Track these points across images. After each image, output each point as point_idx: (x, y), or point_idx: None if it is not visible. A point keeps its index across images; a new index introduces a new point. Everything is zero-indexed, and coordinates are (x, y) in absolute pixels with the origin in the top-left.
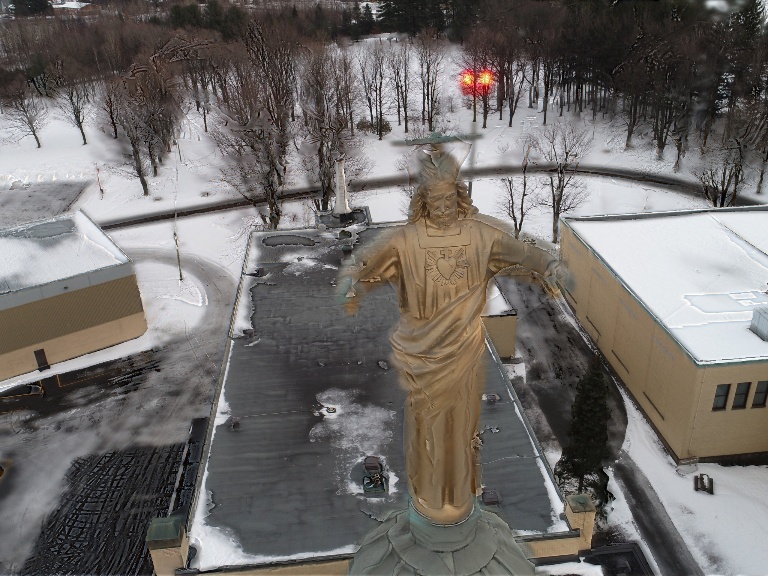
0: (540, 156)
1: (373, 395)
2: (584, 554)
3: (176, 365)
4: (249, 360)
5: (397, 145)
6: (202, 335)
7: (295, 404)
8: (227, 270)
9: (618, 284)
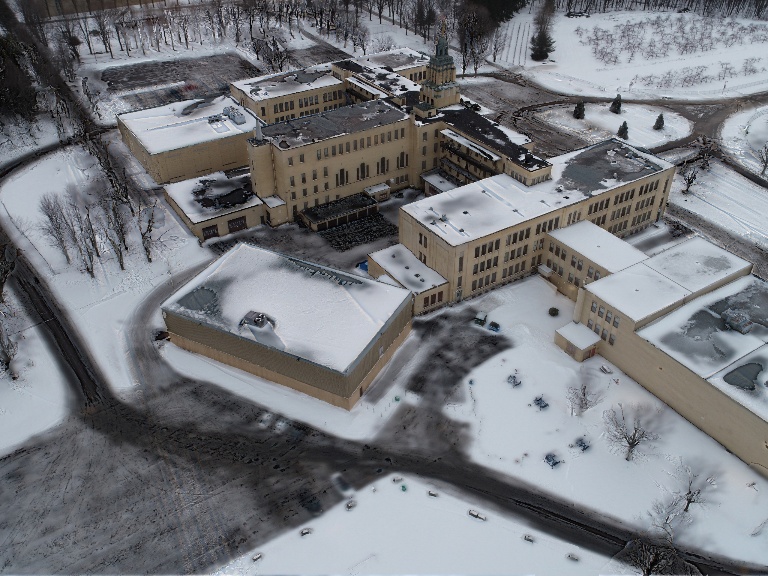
0: None
1: None
2: None
3: None
4: None
5: None
6: None
7: None
8: (161, 284)
9: None
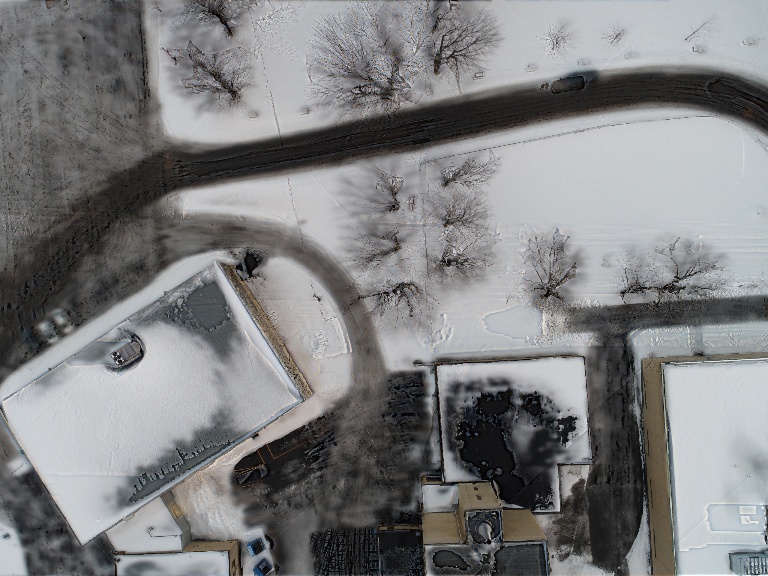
0: (709, 45)
1: None
2: None
3: (347, 439)
4: None
5: (532, 3)
6: (357, 400)
7: None
8: (357, 287)
9: (668, 491)
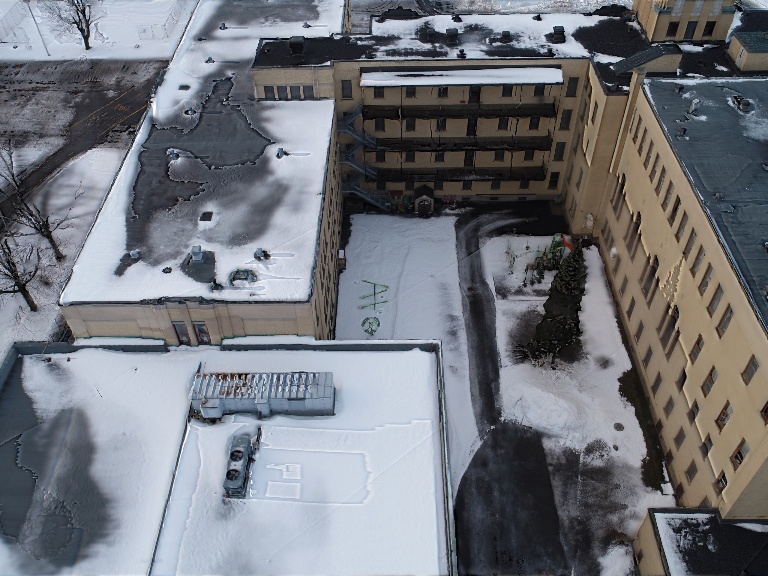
0: None
1: (764, 147)
2: None
3: None
4: None
5: None
6: None
7: None
8: None
9: None
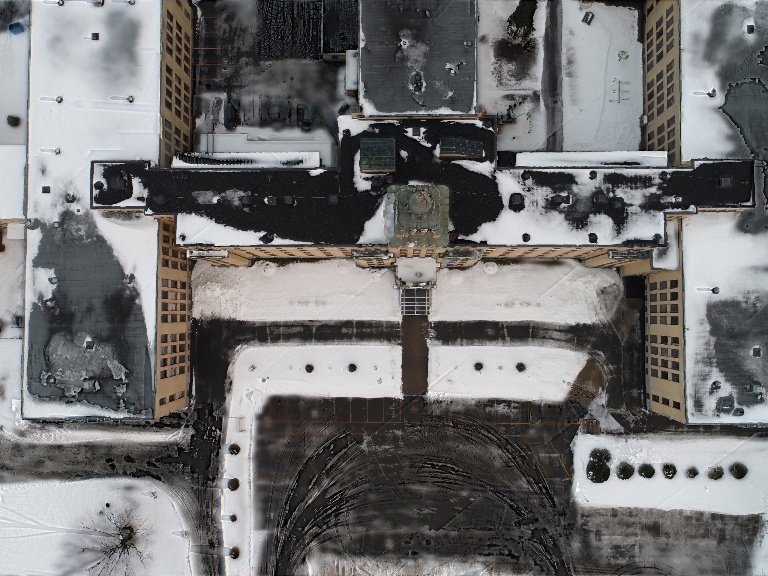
0: None
1: (422, 35)
2: (479, 118)
3: None
4: (370, 3)
5: None
6: None
7: (391, 37)
8: None
9: None
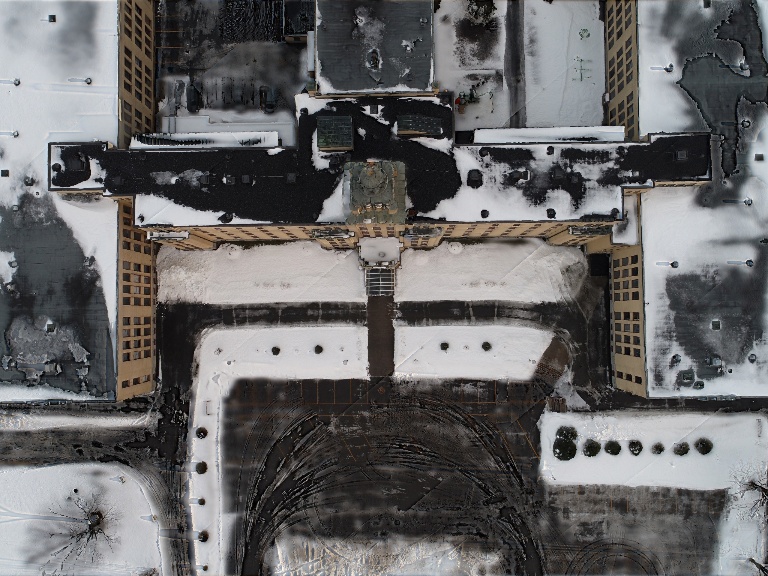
0: None
1: (378, 12)
2: (437, 94)
3: None
4: None
5: None
6: None
7: (347, 15)
8: None
9: None
